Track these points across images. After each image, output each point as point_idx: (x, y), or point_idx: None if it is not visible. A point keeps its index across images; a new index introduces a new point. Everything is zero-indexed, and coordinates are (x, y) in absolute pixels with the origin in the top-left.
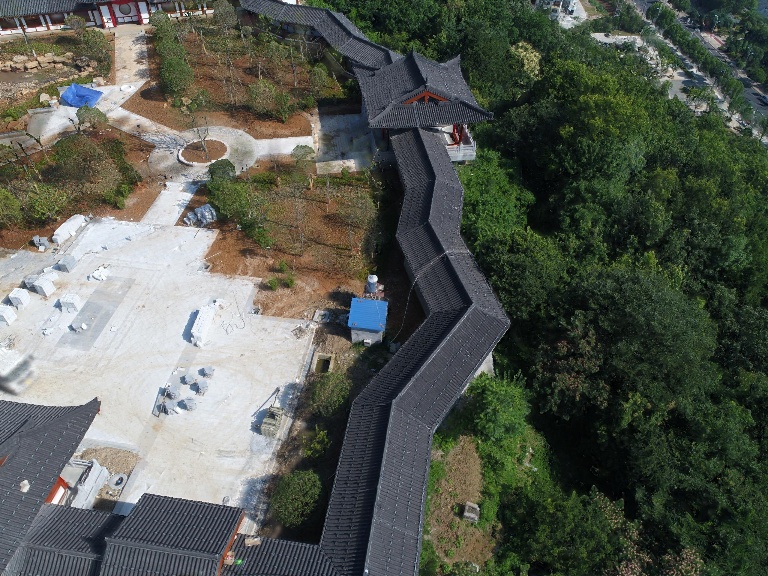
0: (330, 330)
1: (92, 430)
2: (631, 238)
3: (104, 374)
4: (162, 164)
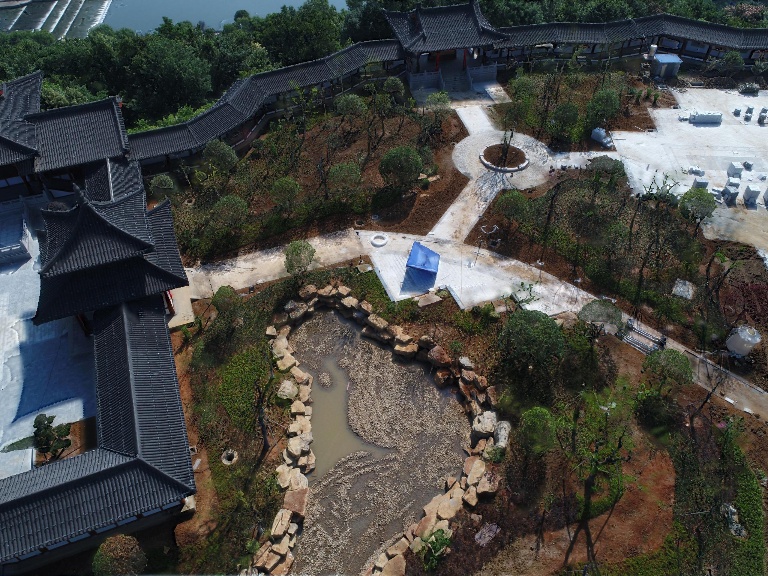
0: (676, 79)
1: None
2: (546, 3)
3: None
4: (532, 178)
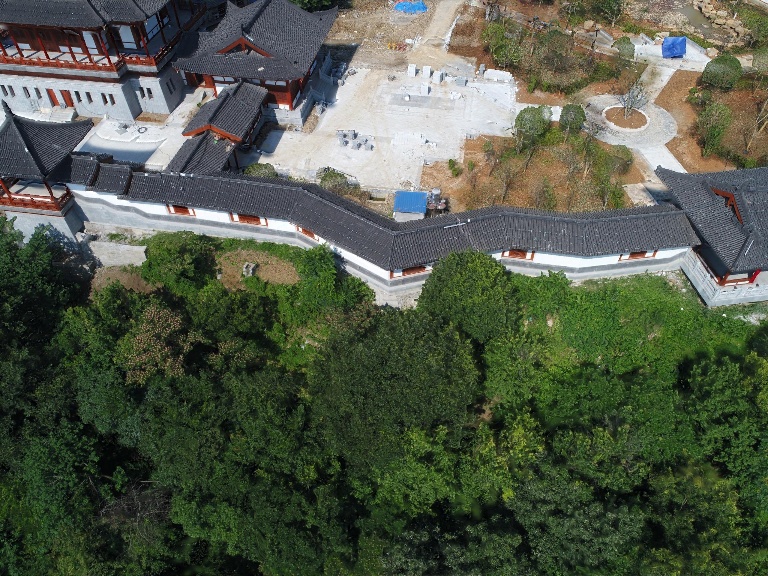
0: None
1: (330, 115)
2: None
3: (370, 112)
4: (598, 101)
